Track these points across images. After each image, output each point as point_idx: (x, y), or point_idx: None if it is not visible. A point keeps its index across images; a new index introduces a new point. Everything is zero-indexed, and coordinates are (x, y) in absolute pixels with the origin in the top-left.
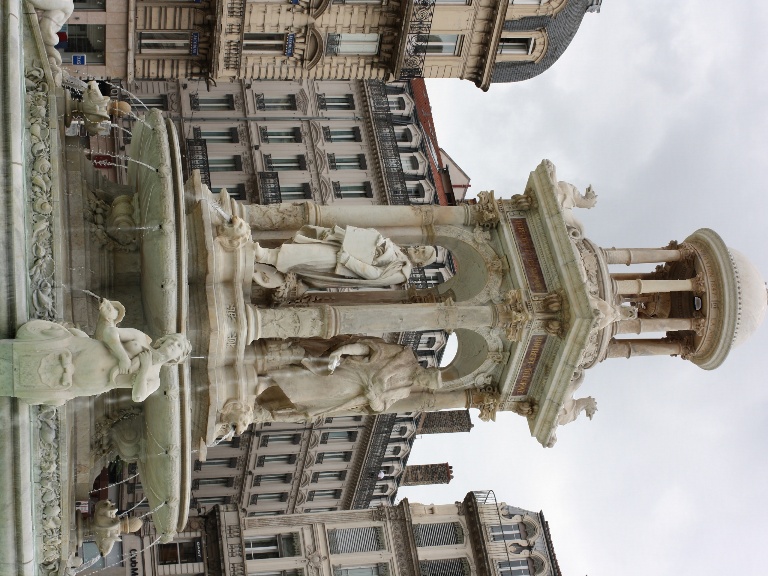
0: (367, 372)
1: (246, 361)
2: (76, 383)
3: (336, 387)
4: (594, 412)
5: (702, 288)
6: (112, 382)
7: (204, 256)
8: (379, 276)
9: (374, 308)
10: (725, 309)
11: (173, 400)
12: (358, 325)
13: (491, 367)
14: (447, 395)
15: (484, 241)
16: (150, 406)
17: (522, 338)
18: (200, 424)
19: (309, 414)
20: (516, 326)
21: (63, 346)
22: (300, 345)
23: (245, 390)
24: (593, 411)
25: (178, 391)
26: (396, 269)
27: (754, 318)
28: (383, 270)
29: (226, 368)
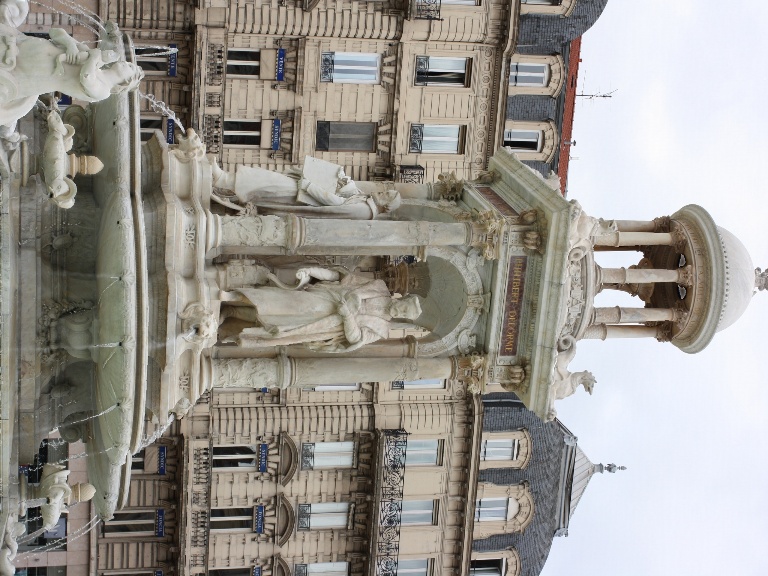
0: (339, 292)
1: (207, 274)
2: (20, 67)
3: (306, 302)
4: (593, 384)
5: (682, 236)
6: (59, 64)
7: (159, 155)
8: (343, 203)
9: (340, 219)
10: (710, 252)
11: (127, 228)
12: (324, 229)
13: (473, 320)
14: (430, 360)
15: (450, 205)
16: (102, 264)
17: (500, 260)
18: (159, 335)
19: (278, 328)
20: (492, 239)
21: (7, 31)
22: (264, 266)
23: (207, 294)
24: (592, 383)
25: (132, 224)
26: (360, 199)
27: (743, 273)
28: (347, 198)
29: (186, 279)
